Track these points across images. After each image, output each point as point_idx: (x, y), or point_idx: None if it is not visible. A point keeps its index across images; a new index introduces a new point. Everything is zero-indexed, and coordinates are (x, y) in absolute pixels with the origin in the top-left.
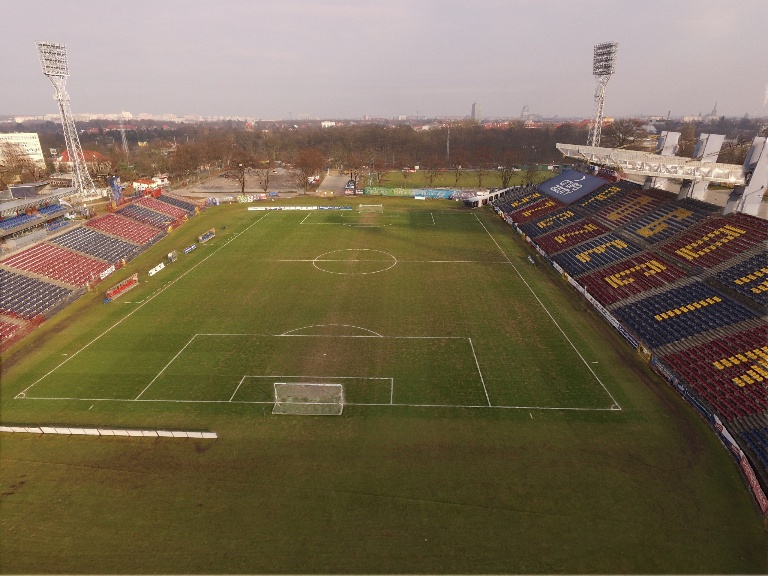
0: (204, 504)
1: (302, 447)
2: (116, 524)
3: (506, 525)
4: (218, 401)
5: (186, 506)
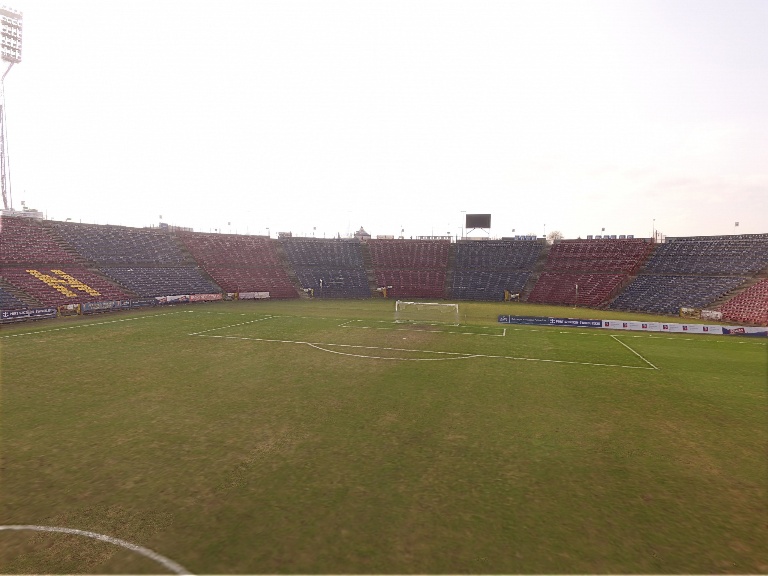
0: (486, 315)
1: (431, 317)
2: (530, 315)
3: (332, 307)
4: (517, 329)
5: (496, 315)
